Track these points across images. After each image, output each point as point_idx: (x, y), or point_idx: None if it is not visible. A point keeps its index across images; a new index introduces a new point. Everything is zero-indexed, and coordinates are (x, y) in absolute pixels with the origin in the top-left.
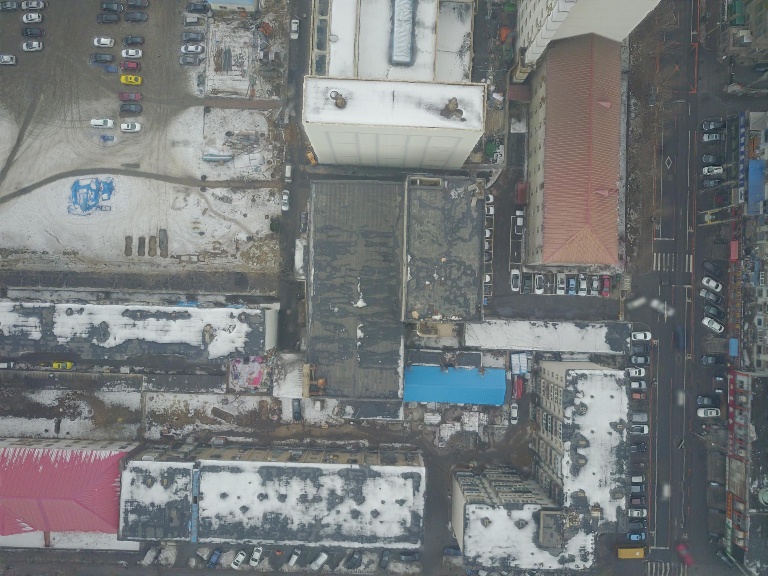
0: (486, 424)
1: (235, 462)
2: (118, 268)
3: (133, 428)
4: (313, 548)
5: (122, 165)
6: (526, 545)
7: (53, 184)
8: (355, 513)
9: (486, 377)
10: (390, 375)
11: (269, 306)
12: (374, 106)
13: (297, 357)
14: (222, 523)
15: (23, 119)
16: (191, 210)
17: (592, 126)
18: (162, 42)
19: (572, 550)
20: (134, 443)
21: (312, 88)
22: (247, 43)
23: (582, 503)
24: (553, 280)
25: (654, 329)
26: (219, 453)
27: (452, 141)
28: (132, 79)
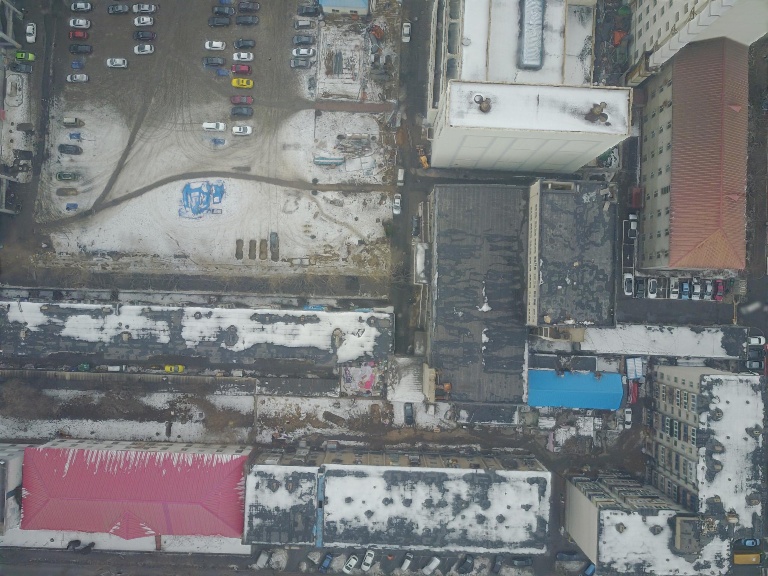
0: (600, 429)
1: (360, 466)
2: (229, 271)
3: (244, 432)
4: (425, 553)
5: (233, 168)
6: (661, 551)
7: (164, 187)
8: (481, 518)
9: (602, 381)
10: (515, 379)
11: (383, 310)
12: (518, 110)
13: (412, 361)
14: (347, 528)
15: (134, 122)
16: (302, 213)
17: (724, 130)
18: (273, 45)
19: (708, 556)
20: (247, 447)
21: (456, 92)
22: (358, 46)
23: (718, 509)
24: (666, 284)
25: (767, 334)
26: (337, 457)
27: (588, 145)
28: (244, 82)
